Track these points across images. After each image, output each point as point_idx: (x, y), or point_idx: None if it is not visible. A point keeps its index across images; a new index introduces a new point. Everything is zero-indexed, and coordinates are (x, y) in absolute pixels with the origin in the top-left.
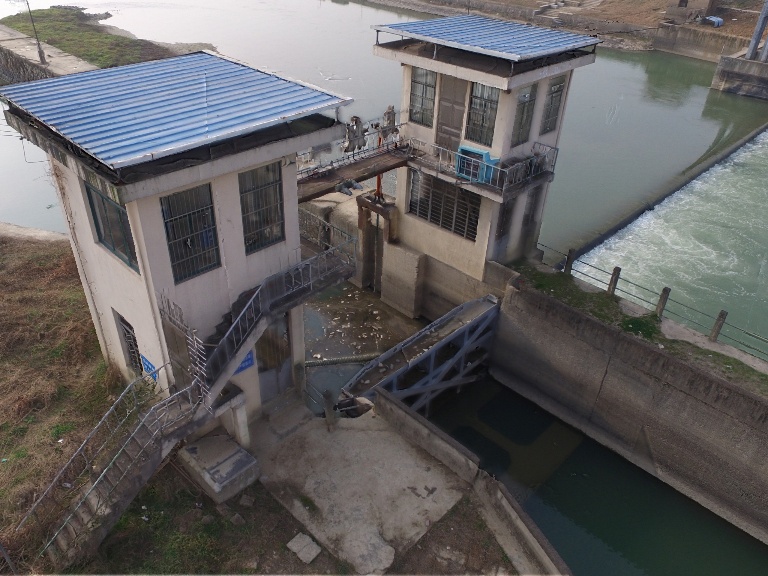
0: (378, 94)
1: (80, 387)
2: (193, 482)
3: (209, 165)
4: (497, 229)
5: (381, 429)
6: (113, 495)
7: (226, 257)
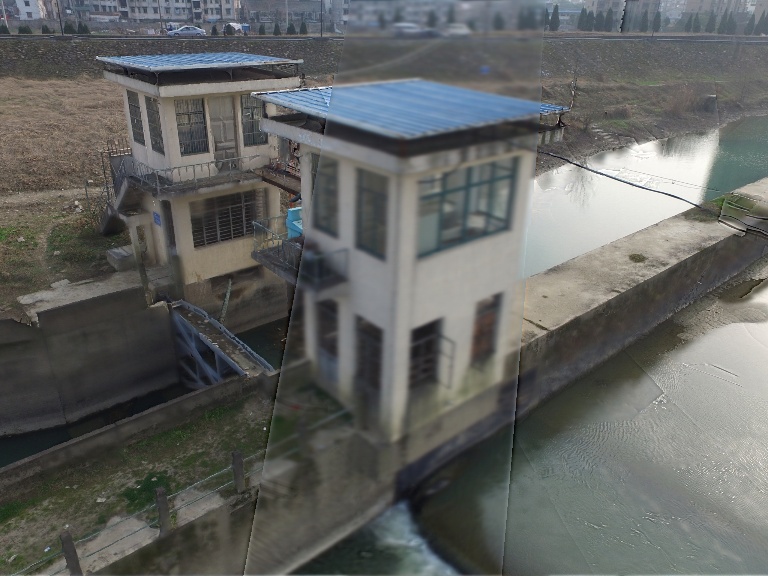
0: None
1: None
2: None
3: (120, 77)
4: None
5: None
6: None
7: None
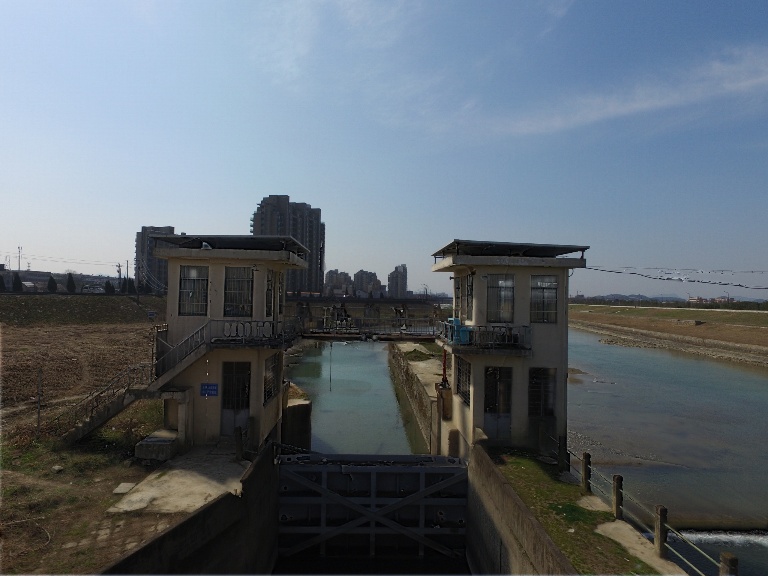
0: (629, 393)
1: None
2: None
3: (198, 250)
4: (490, 401)
5: None
6: None
7: (211, 312)
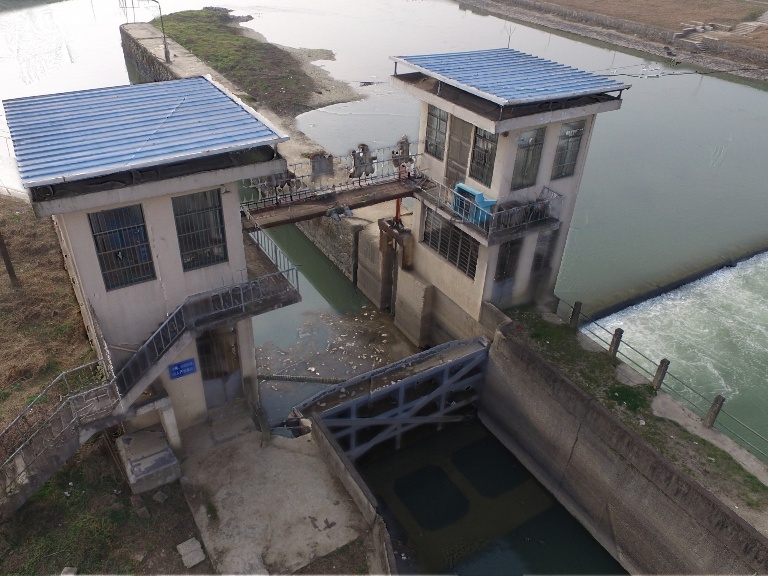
0: None
1: (68, 365)
2: (121, 470)
3: (129, 189)
4: (498, 271)
5: (310, 454)
6: (33, 468)
7: (162, 271)
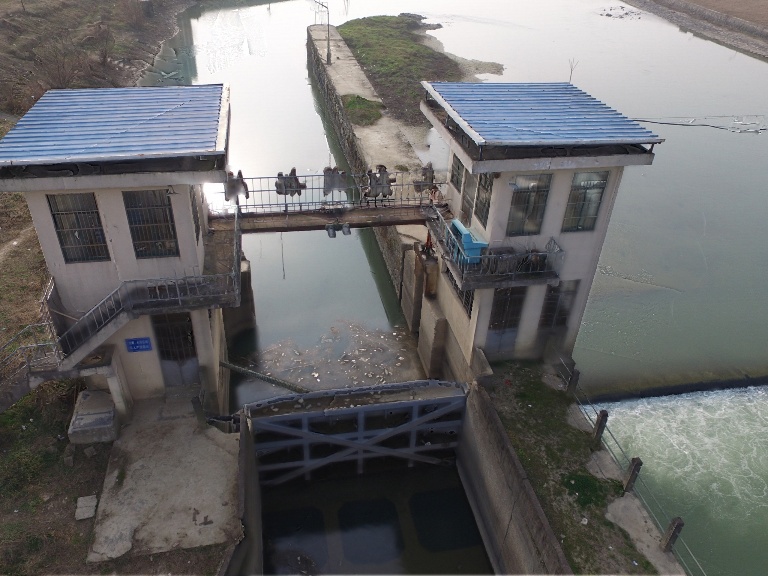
0: None
1: None
2: None
3: (73, 179)
4: (496, 318)
5: (231, 452)
6: None
7: (116, 255)
